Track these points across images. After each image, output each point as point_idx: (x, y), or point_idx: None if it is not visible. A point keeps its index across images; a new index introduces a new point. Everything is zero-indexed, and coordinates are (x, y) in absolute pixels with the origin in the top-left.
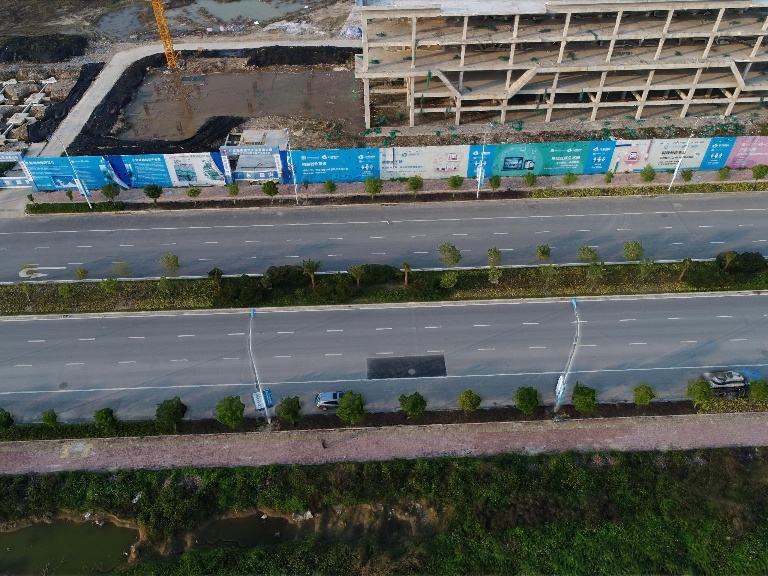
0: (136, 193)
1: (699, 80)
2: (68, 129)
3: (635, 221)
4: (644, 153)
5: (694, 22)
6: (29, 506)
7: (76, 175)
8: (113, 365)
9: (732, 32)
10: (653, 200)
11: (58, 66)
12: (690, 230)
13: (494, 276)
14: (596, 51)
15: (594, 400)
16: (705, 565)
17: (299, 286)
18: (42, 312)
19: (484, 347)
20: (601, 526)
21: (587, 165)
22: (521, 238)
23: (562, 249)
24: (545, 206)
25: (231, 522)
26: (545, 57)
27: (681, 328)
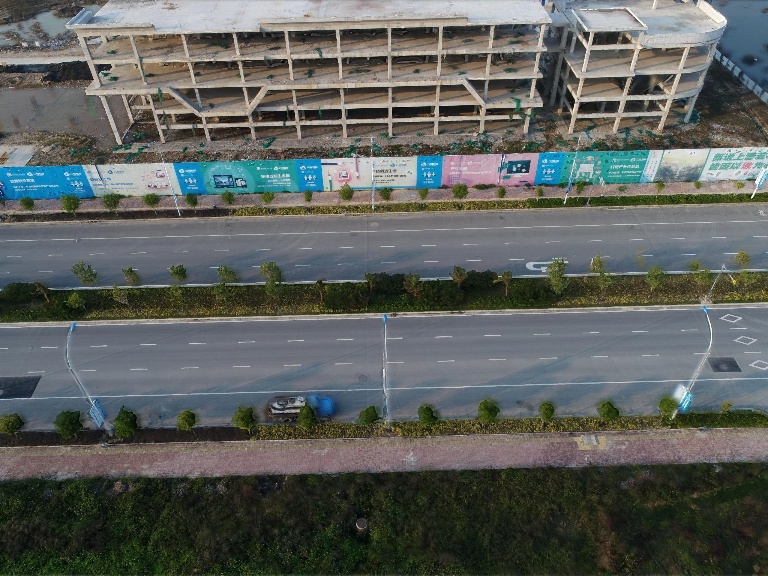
0: None
1: (444, 97)
2: None
3: (321, 240)
4: (354, 171)
5: (429, 40)
6: None
7: None
8: None
9: (458, 50)
10: (353, 219)
11: None
12: (369, 250)
13: None
14: (338, 68)
15: (134, 425)
16: None
17: None
18: None
19: (86, 368)
20: (77, 555)
21: (300, 183)
22: (196, 257)
23: (229, 268)
24: (242, 224)
25: None
26: (283, 74)
27: (294, 351)
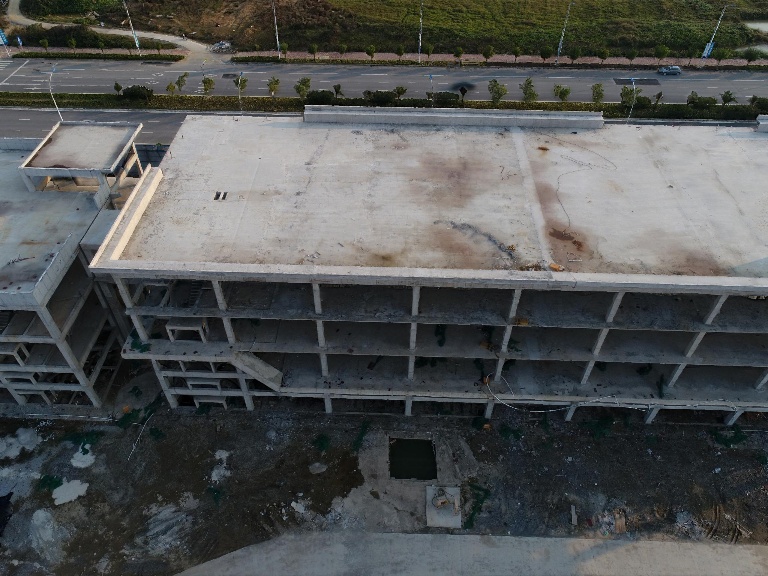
0: None
1: None
2: None
3: None
4: None
5: None
6: None
7: None
8: None
9: None
10: None
11: None
12: None
13: None
14: None
15: None
16: (504, 35)
17: None
18: None
19: None
20: None
21: None
22: None
23: None
24: None
25: None
26: None
27: (474, 88)
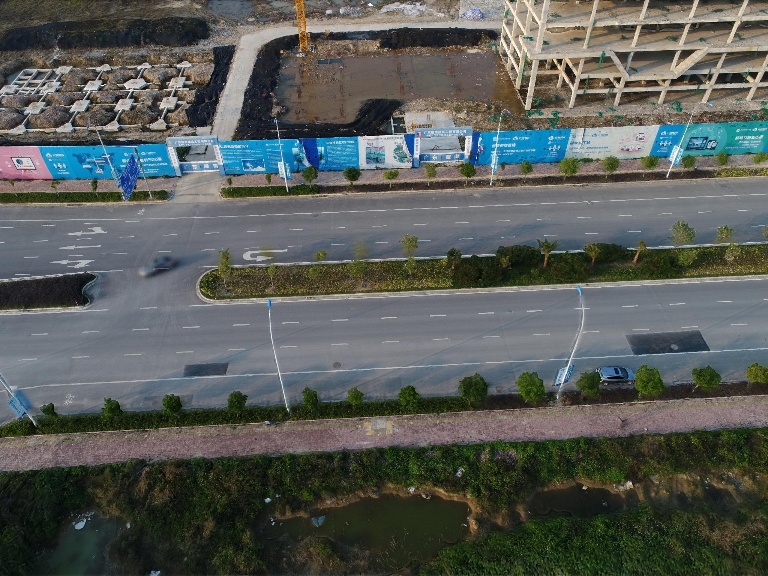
0: (325, 176)
1: None
2: (227, 113)
3: None
4: None
5: None
6: (357, 481)
7: (282, 158)
8: (378, 345)
9: None
10: None
11: (188, 49)
12: None
13: (733, 253)
14: (759, 31)
15: None
16: None
17: (530, 266)
18: (285, 294)
19: (735, 322)
20: None
21: (767, 144)
22: (727, 216)
23: None
24: (736, 185)
25: (554, 493)
26: (712, 37)
27: None
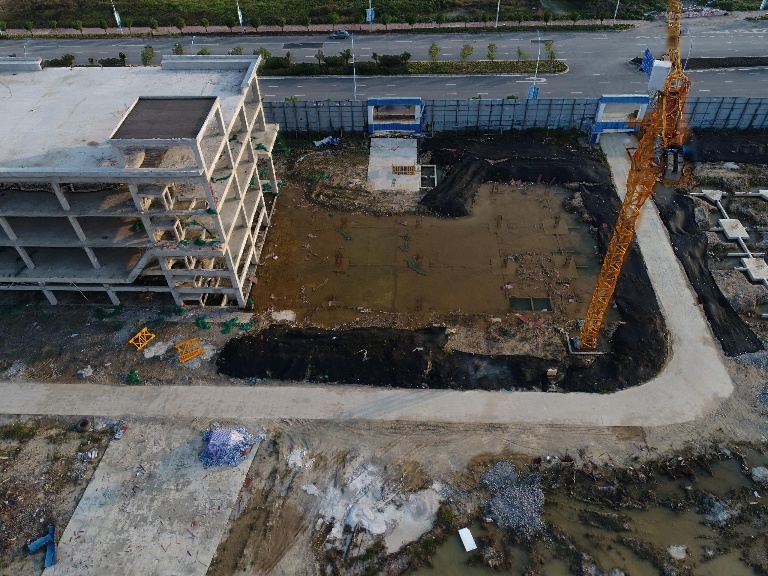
0: None
1: None
2: None
3: None
4: None
5: None
6: None
7: None
8: None
9: None
10: None
11: None
12: None
13: None
14: None
15: None
16: (221, 9)
17: None
18: None
19: None
20: None
21: None
22: None
23: None
24: None
25: None
26: None
27: None
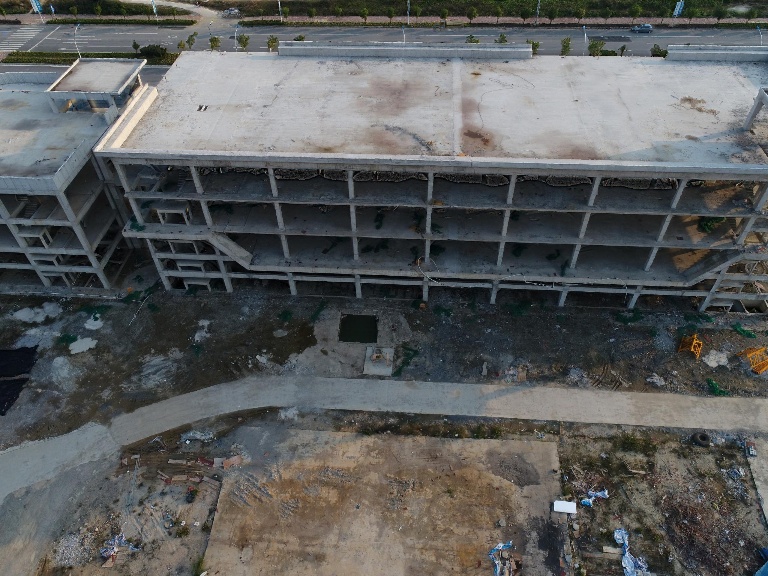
0: None
1: None
2: None
3: None
4: None
5: None
6: None
7: None
8: None
9: None
10: None
11: None
12: None
13: None
14: None
15: None
16: None
17: None
18: None
19: None
20: None
21: None
22: None
23: None
24: None
25: None
26: None
27: None
